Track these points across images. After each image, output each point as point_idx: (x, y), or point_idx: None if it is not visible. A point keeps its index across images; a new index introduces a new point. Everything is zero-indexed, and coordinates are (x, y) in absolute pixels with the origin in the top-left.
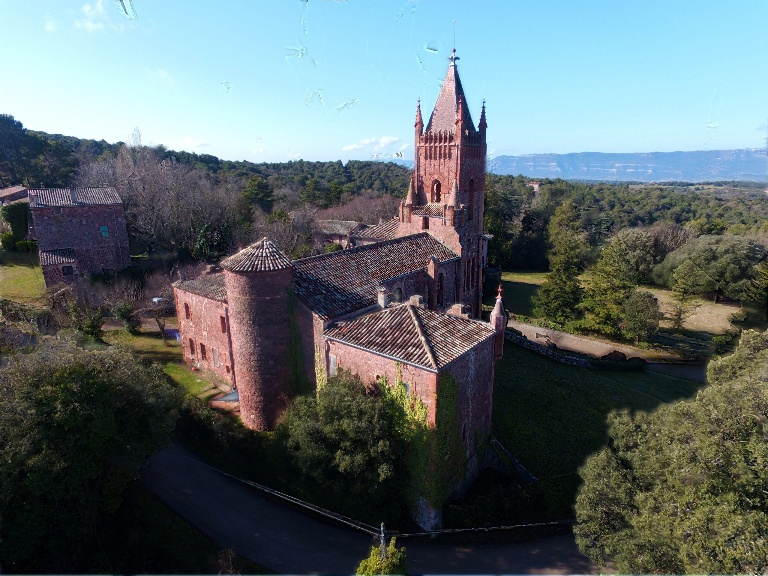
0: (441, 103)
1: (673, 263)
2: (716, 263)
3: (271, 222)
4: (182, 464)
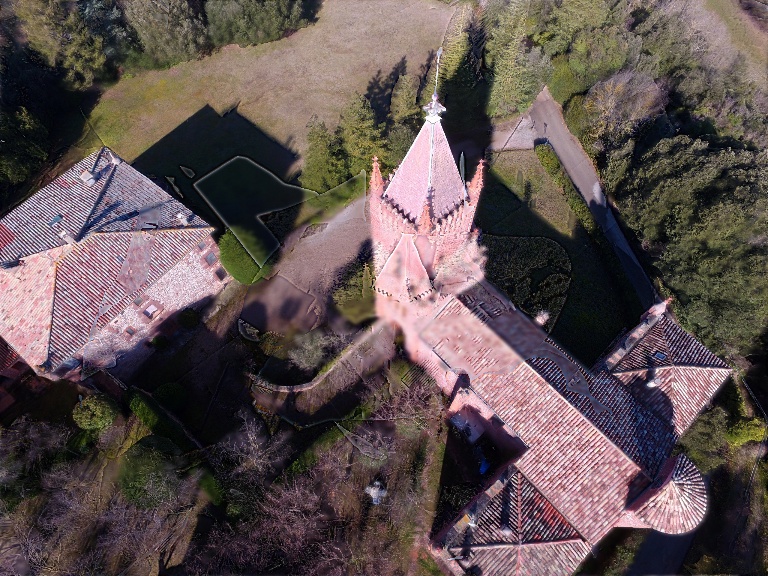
0: (438, 178)
1: (227, 18)
2: (269, 1)
3: (40, 538)
4: (641, 571)
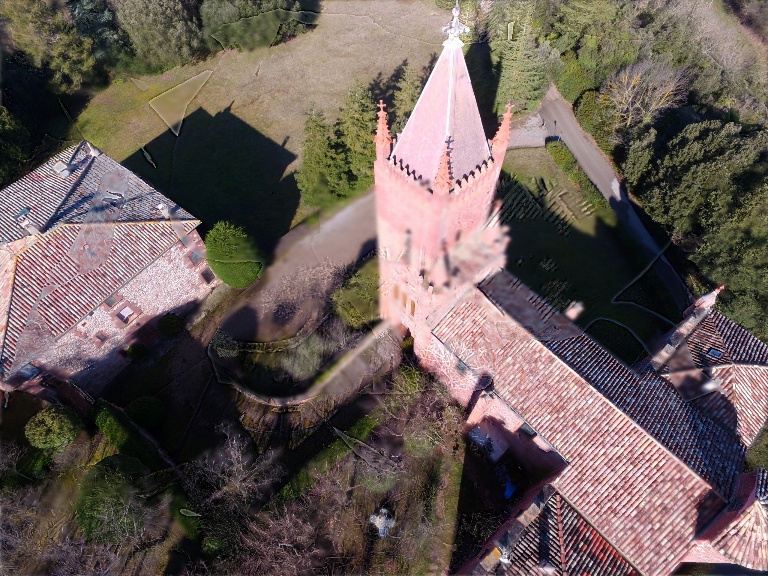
0: None
1: (222, 21)
2: (266, 4)
3: None
4: None
